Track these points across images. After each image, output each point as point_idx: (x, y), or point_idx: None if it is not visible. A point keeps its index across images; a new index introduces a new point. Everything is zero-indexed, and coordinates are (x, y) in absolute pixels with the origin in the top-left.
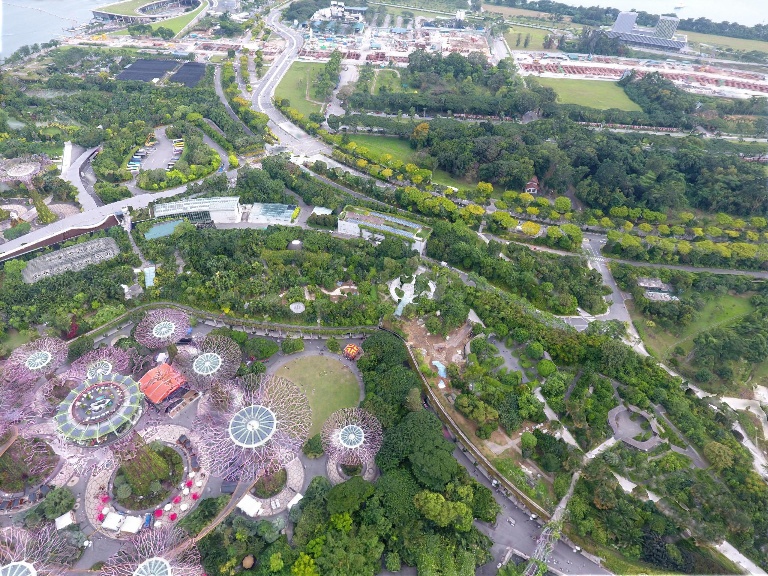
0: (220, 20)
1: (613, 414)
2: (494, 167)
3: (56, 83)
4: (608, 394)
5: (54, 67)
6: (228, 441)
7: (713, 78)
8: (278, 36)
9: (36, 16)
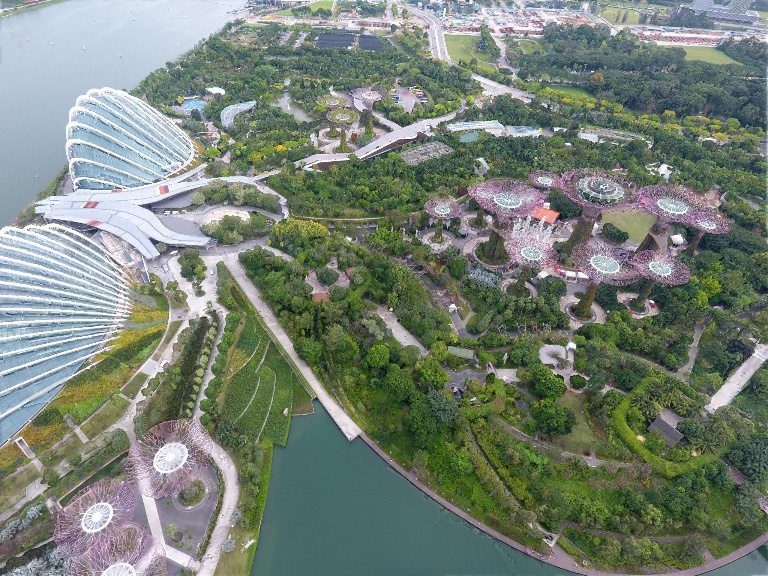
0: (354, 3)
1: None
2: (672, 100)
3: (276, 50)
4: None
5: (261, 39)
6: (665, 212)
7: None
8: (413, 16)
9: (190, 2)
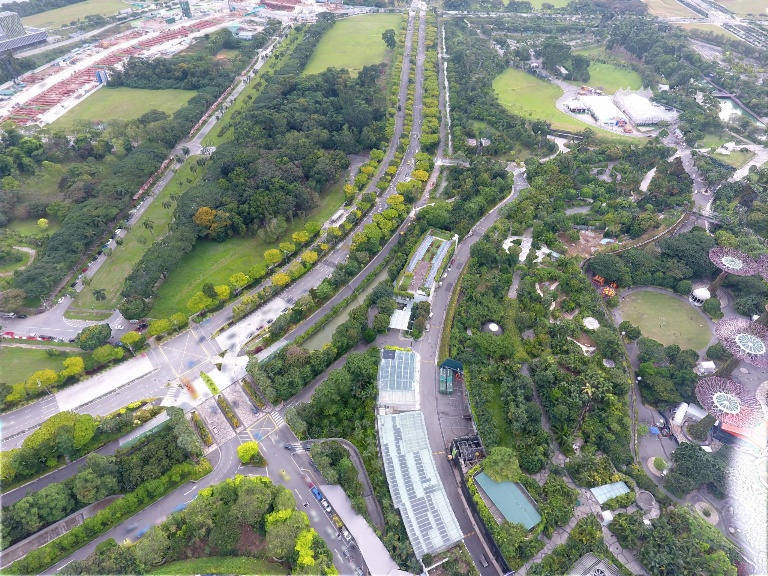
0: None
1: (603, 179)
2: (324, 174)
3: None
4: (593, 176)
5: None
6: None
7: (128, 47)
8: None
9: None
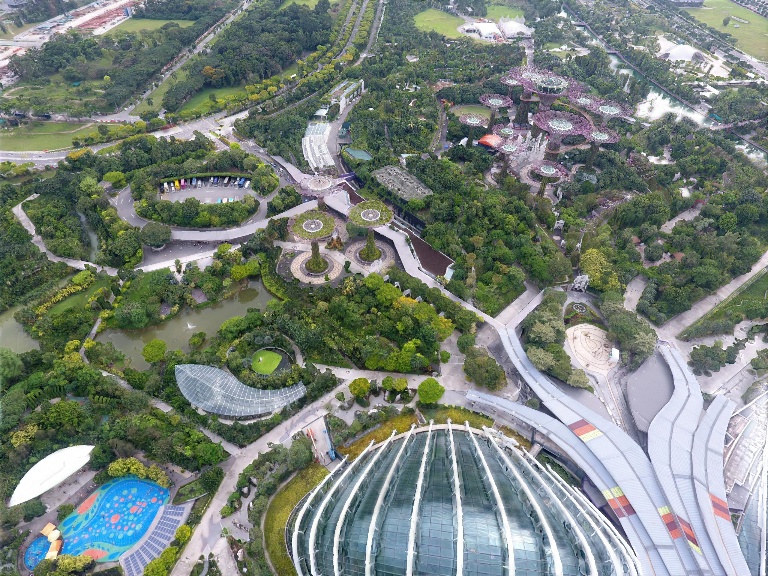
0: None
1: None
2: (284, 54)
3: None
4: None
5: None
6: None
7: None
8: None
9: None
